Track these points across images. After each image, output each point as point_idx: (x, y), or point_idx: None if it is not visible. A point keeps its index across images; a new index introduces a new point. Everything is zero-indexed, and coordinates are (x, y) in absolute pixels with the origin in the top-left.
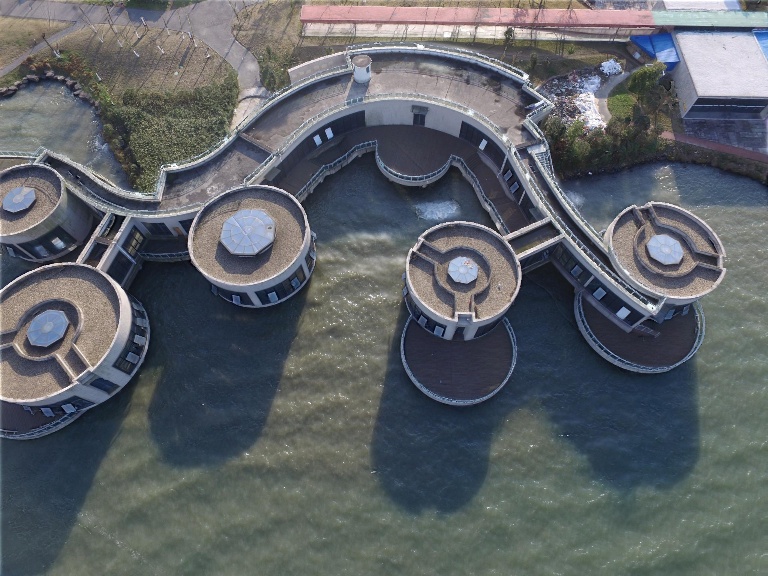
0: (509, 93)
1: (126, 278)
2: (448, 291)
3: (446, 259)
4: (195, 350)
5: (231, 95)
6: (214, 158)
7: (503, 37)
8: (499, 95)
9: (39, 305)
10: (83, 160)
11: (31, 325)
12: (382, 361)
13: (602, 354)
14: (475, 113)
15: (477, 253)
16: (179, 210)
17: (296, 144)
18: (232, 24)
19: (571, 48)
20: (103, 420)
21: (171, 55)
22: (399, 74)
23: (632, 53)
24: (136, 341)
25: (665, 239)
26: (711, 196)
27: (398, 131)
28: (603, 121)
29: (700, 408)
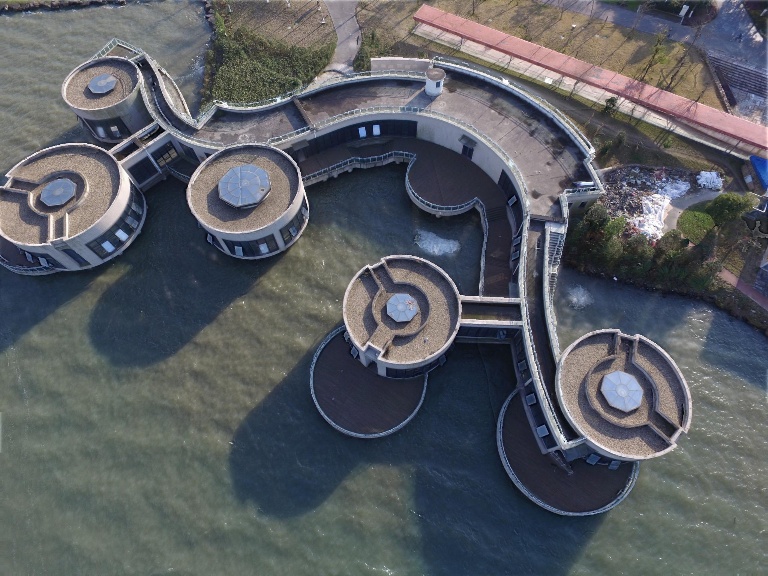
0: (567, 161)
1: (147, 181)
2: (375, 319)
3: (394, 290)
4: (163, 265)
5: (318, 63)
6: (262, 111)
7: (606, 104)
8: (555, 159)
9: (64, 172)
10: (180, 73)
11: (49, 184)
12: (299, 353)
13: (502, 459)
14: (517, 166)
15: (426, 298)
16: (208, 143)
17: (337, 127)
18: (360, 1)
19: (668, 142)
20: (67, 285)
21: (294, 10)
22: (470, 100)
23: (745, 174)
24: (118, 234)
25: (629, 380)
26: (742, 366)
27: (444, 154)
28: (662, 232)
29: (573, 571)
